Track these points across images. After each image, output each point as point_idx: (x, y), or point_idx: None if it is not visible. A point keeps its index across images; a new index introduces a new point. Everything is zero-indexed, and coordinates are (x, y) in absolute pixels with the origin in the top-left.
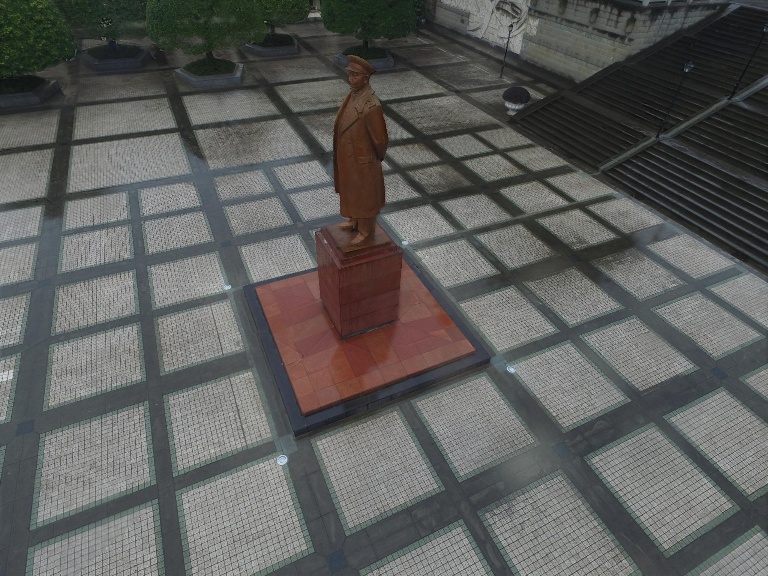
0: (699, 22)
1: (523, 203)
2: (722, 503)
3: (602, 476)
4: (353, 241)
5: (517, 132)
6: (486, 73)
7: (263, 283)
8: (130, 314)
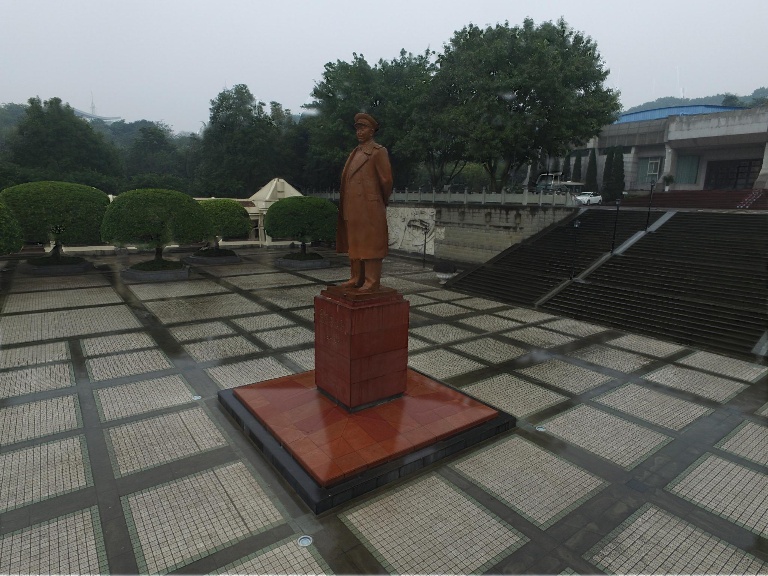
0: (564, 219)
1: (483, 326)
2: None
3: (695, 502)
4: (361, 288)
5: (454, 292)
6: (410, 266)
7: None
8: (70, 428)
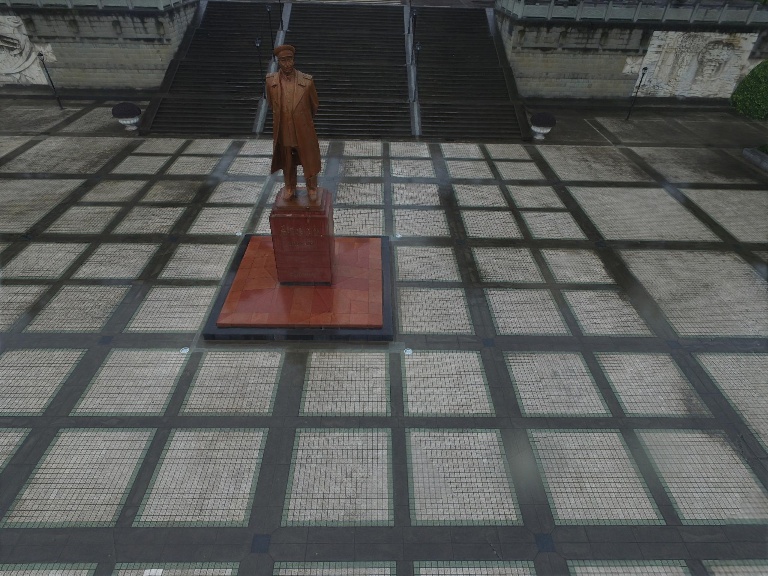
0: (194, 17)
1: (254, 172)
2: (507, 214)
3: (480, 237)
4: (313, 198)
5: (162, 138)
6: (39, 110)
7: (212, 320)
8: (150, 437)
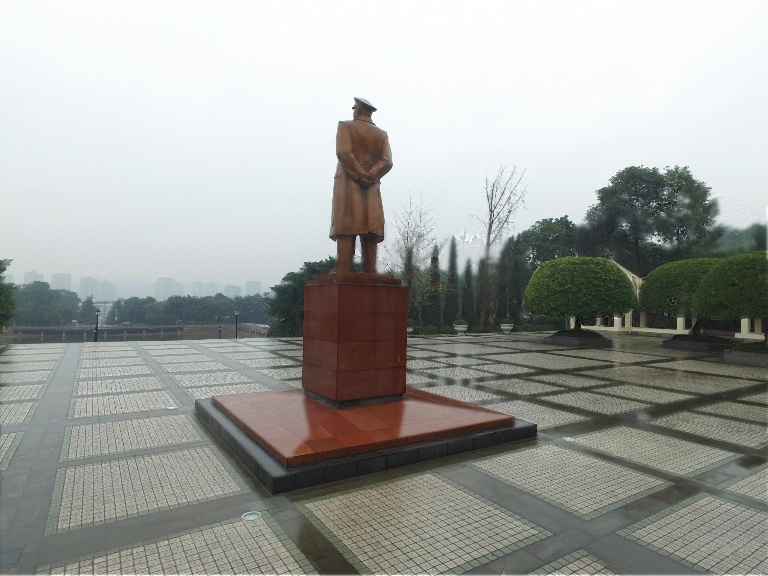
0: None
1: None
2: None
3: None
4: None
5: None
6: None
7: None
8: None
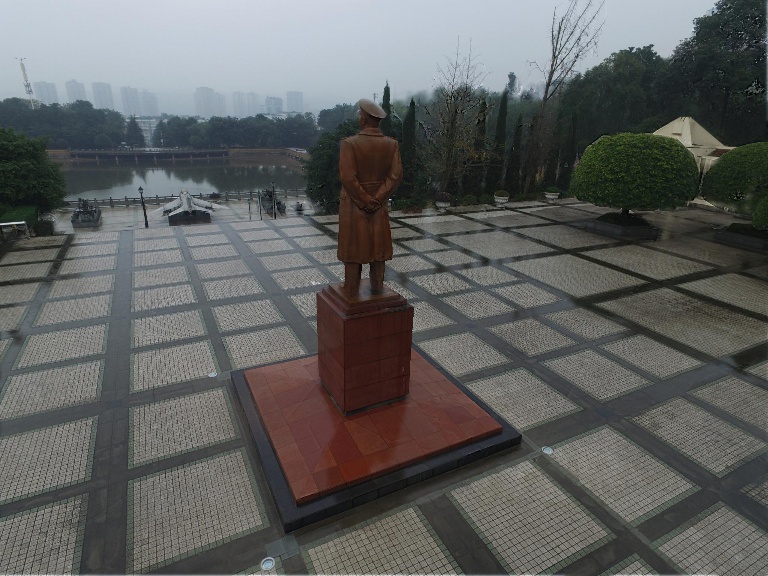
0: None
1: None
2: None
3: None
4: None
5: None
6: None
7: None
8: None
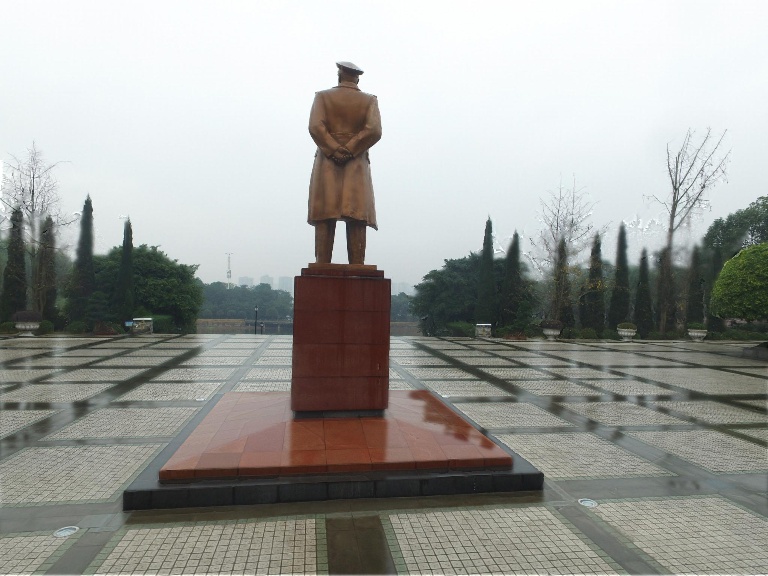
0: None
1: None
2: None
3: None
4: None
5: None
6: None
7: (438, 396)
8: (416, 377)
